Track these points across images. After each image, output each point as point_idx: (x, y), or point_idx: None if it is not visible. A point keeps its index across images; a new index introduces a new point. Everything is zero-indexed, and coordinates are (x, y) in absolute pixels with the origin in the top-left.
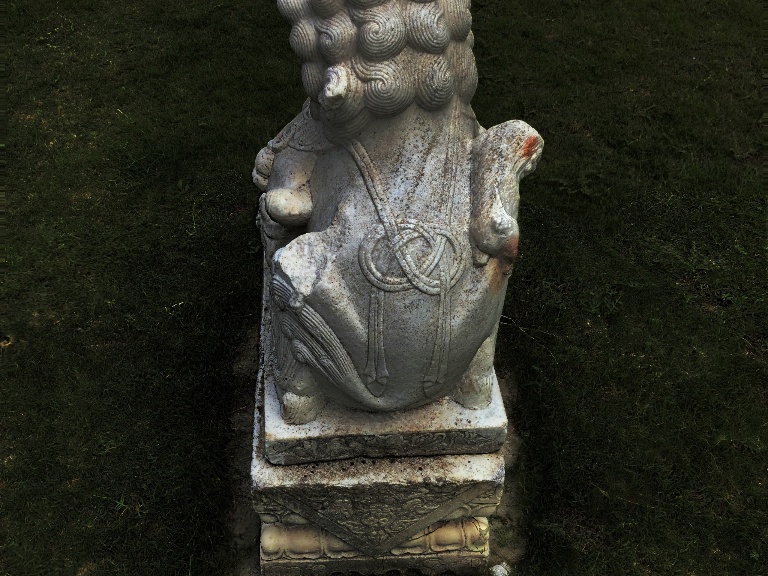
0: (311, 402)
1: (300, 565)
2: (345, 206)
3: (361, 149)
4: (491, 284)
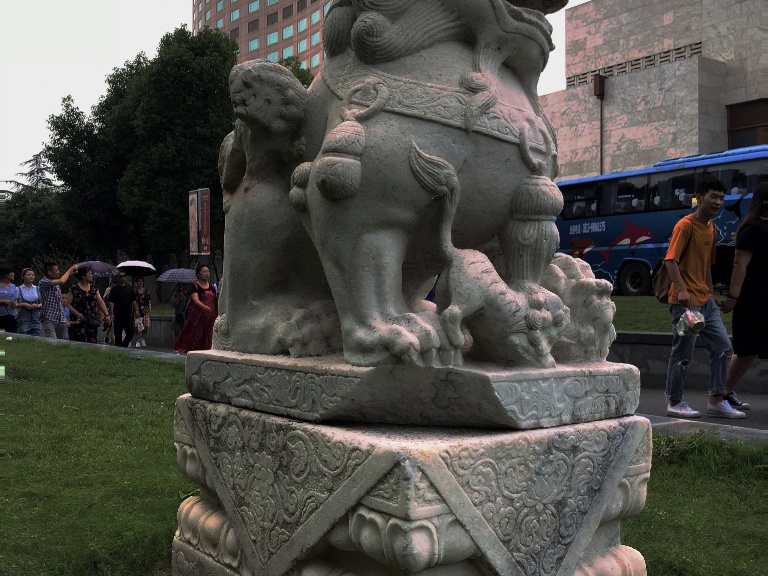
0: None
1: None
2: None
3: None
4: None
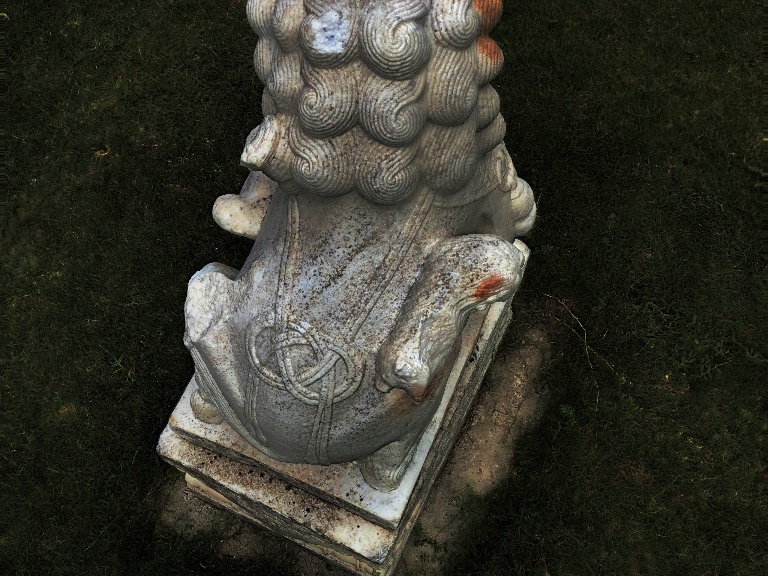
0: (216, 410)
1: (219, 504)
2: (257, 268)
3: (295, 211)
4: (390, 412)
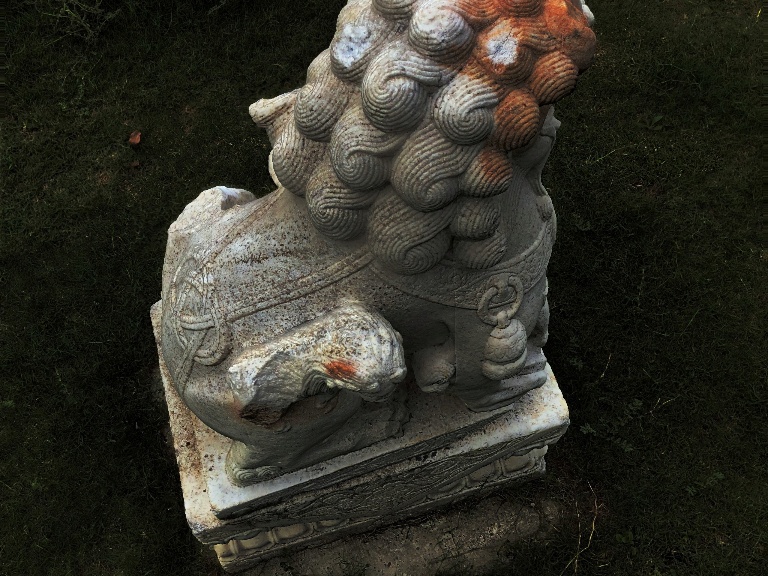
0: None
1: None
2: (233, 210)
3: None
4: (228, 407)
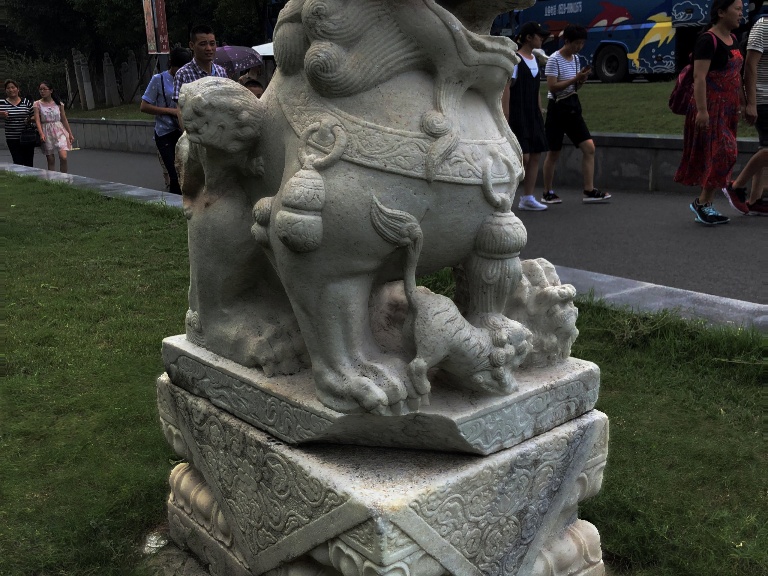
0: None
1: None
2: None
3: None
4: None
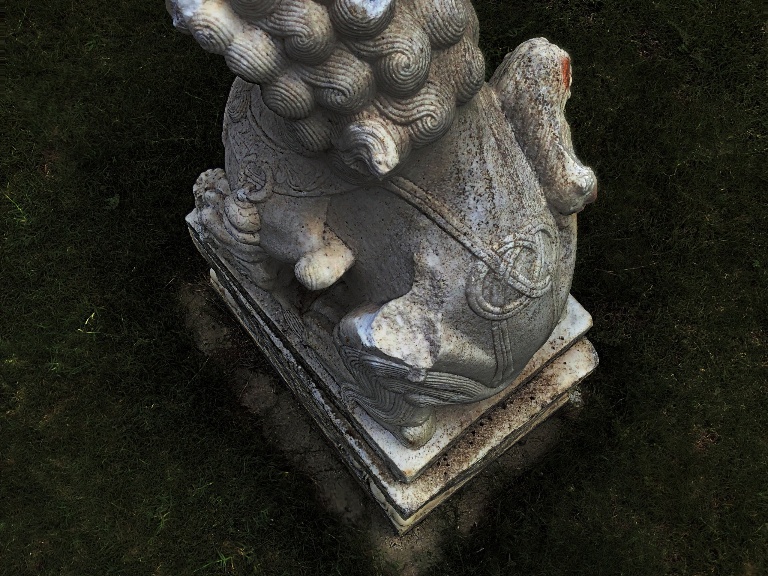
0: (431, 421)
1: None
2: (423, 257)
3: (406, 184)
4: None
